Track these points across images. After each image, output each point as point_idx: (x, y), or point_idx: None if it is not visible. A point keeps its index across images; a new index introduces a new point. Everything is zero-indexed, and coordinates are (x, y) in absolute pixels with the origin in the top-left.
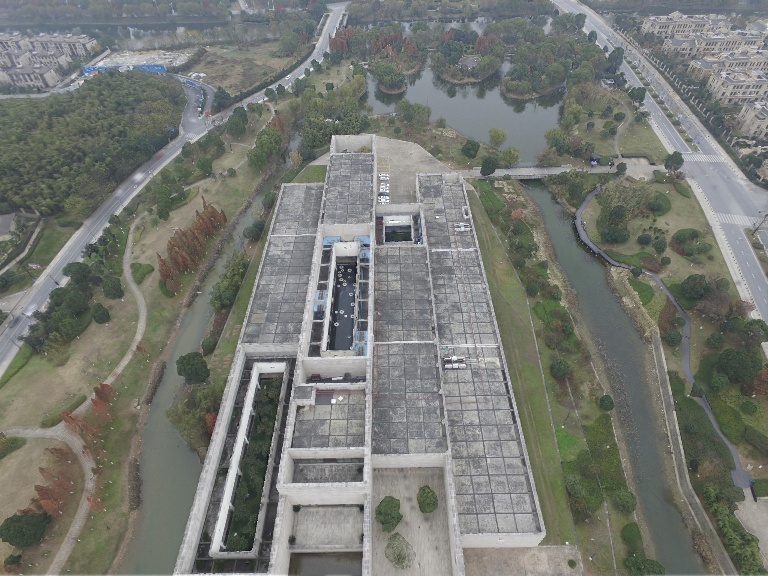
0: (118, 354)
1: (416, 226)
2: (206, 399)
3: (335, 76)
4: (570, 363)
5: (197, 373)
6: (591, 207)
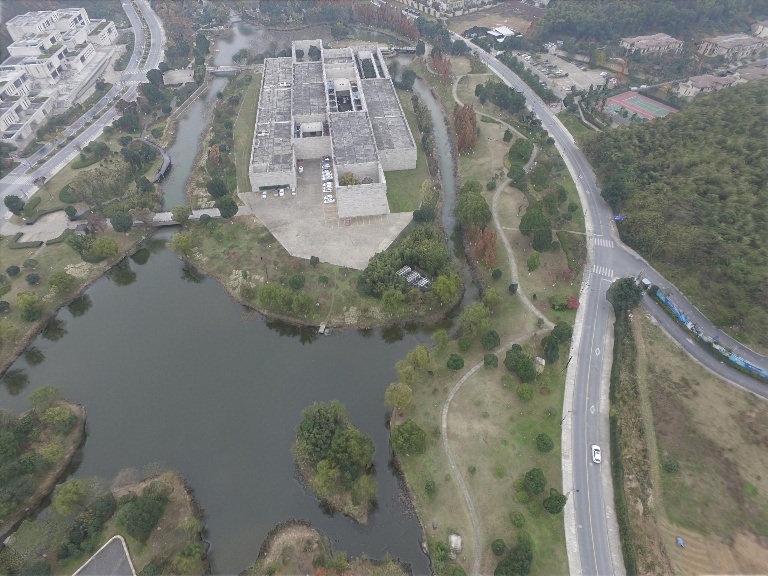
0: None
1: None
2: None
3: (475, 458)
4: None
5: None
6: None
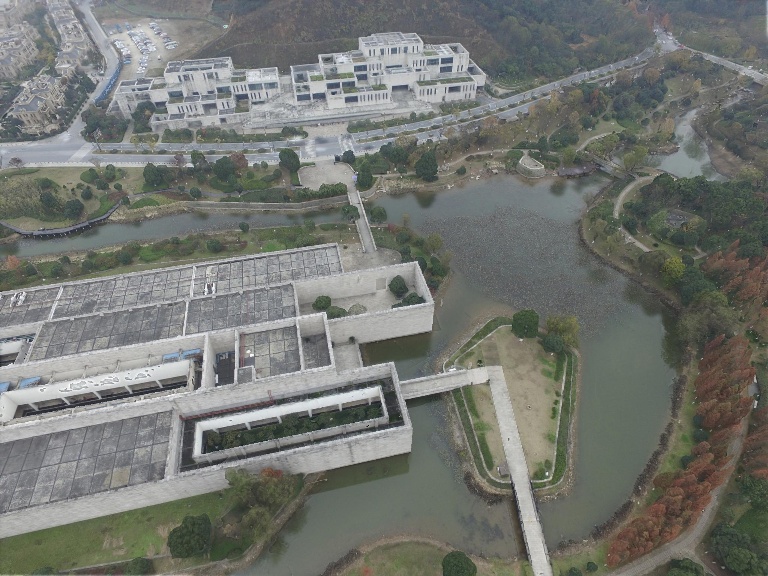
0: None
1: None
2: (248, 476)
3: None
4: None
5: (204, 520)
6: (19, 223)
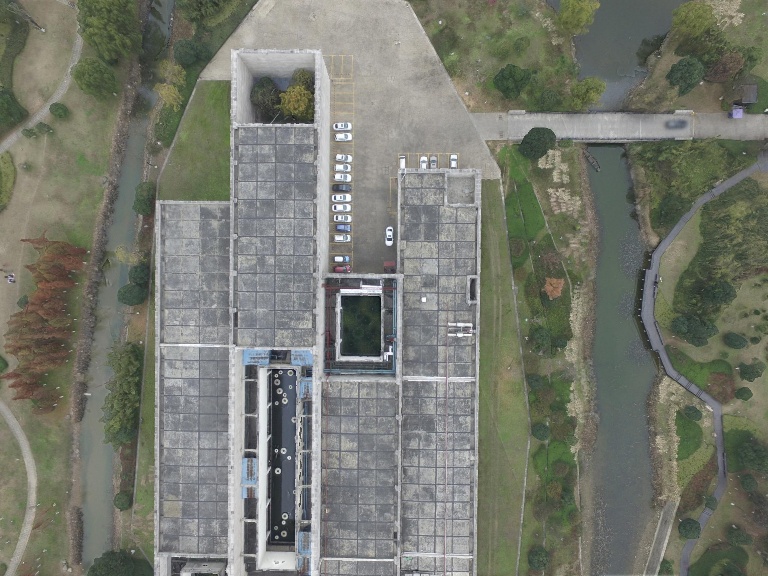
0: (17, 508)
1: (390, 302)
2: None
3: None
4: (555, 539)
5: None
6: (685, 238)
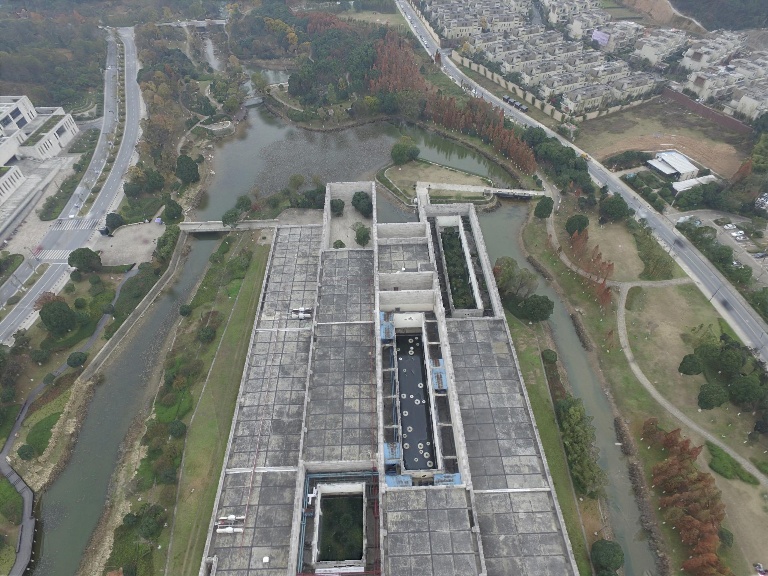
0: None
1: (308, 558)
2: None
3: None
4: (191, 349)
5: None
6: None
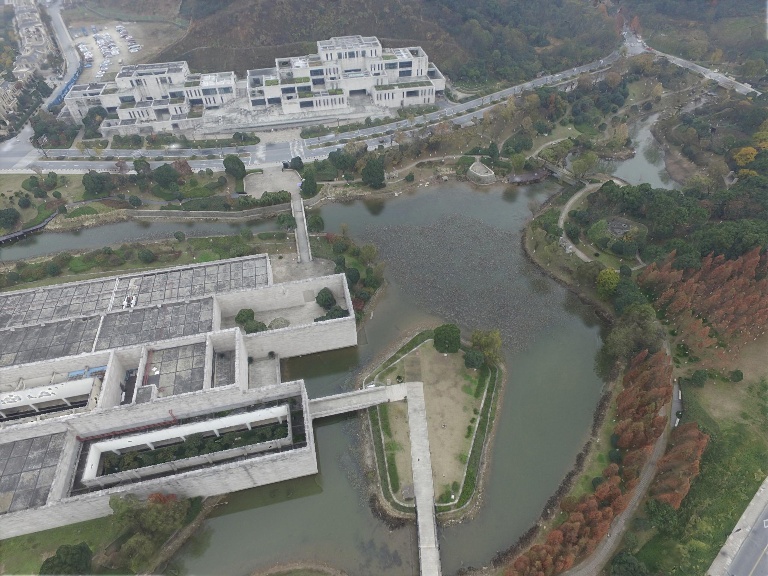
0: None
1: None
2: (130, 502)
3: None
4: None
5: (80, 550)
6: None
